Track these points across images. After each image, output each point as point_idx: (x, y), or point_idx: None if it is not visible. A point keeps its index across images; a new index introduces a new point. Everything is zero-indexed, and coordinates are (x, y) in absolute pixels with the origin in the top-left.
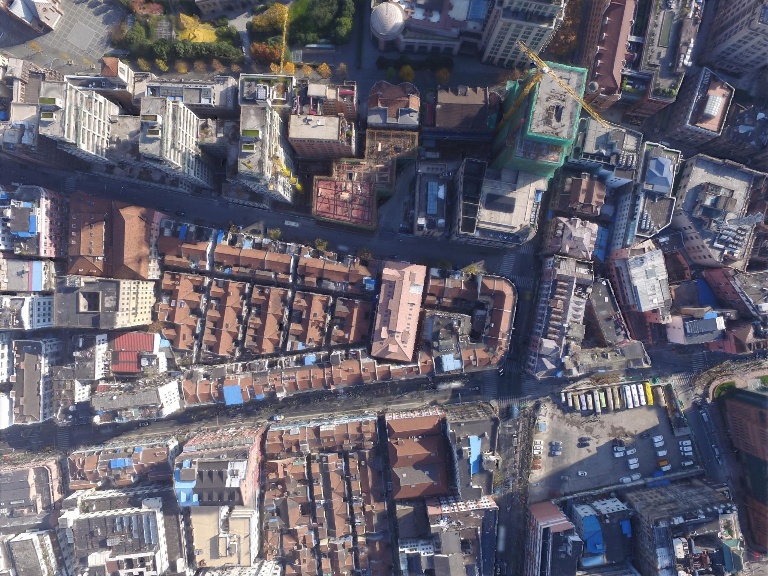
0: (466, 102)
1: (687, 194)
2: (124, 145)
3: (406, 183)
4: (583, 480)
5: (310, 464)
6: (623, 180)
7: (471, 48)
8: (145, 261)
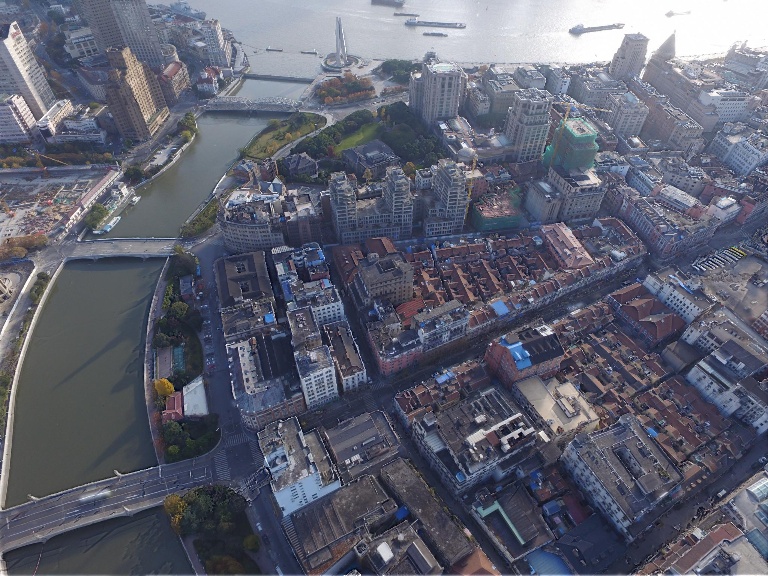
0: (528, 162)
1: (658, 166)
2: (365, 209)
3: (518, 208)
4: (759, 307)
5: None
6: (625, 168)
7: (510, 159)
8: None
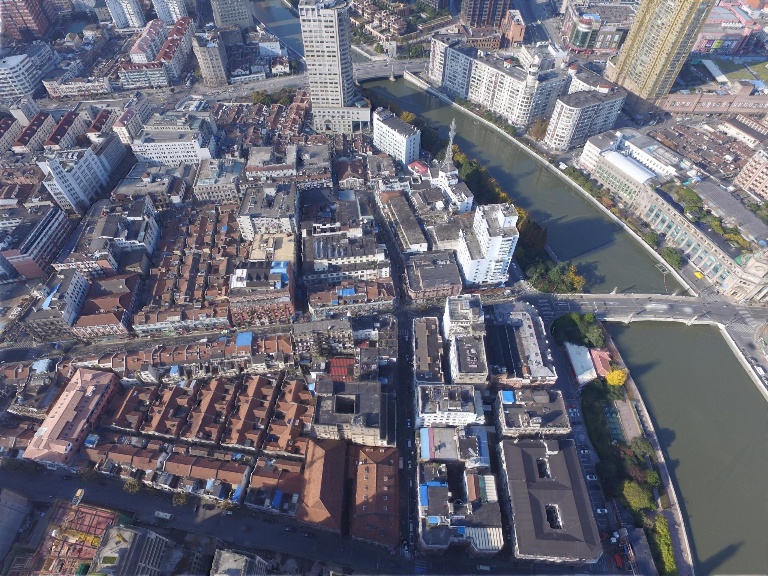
0: None
1: None
2: None
3: None
4: None
5: (203, 298)
6: None
7: None
8: (309, 458)
